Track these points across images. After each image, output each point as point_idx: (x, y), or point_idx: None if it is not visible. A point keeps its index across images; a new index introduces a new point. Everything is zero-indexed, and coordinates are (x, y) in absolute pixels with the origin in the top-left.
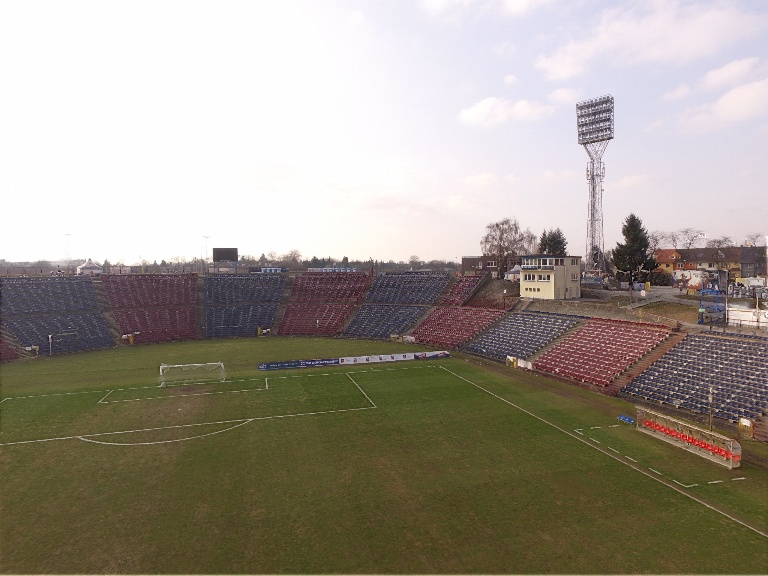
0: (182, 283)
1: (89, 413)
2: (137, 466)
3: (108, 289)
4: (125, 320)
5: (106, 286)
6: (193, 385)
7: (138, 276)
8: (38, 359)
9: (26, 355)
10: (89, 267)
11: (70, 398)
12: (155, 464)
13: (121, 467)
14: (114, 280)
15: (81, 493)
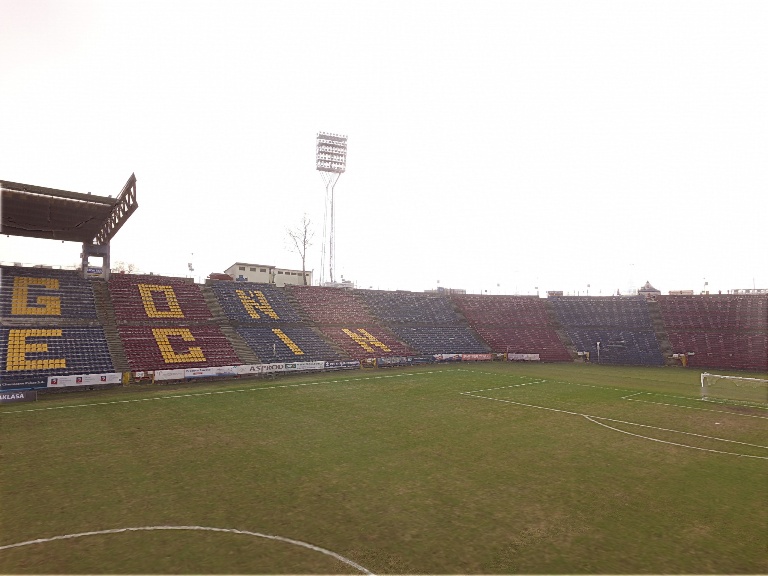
0: (759, 304)
1: (606, 402)
2: (629, 454)
3: (663, 309)
4: (680, 341)
5: (661, 306)
6: (751, 407)
7: (699, 296)
8: (588, 364)
9: (579, 360)
10: (647, 289)
11: (596, 390)
12: (653, 459)
13: (611, 448)
14: (670, 300)
15: (556, 454)
